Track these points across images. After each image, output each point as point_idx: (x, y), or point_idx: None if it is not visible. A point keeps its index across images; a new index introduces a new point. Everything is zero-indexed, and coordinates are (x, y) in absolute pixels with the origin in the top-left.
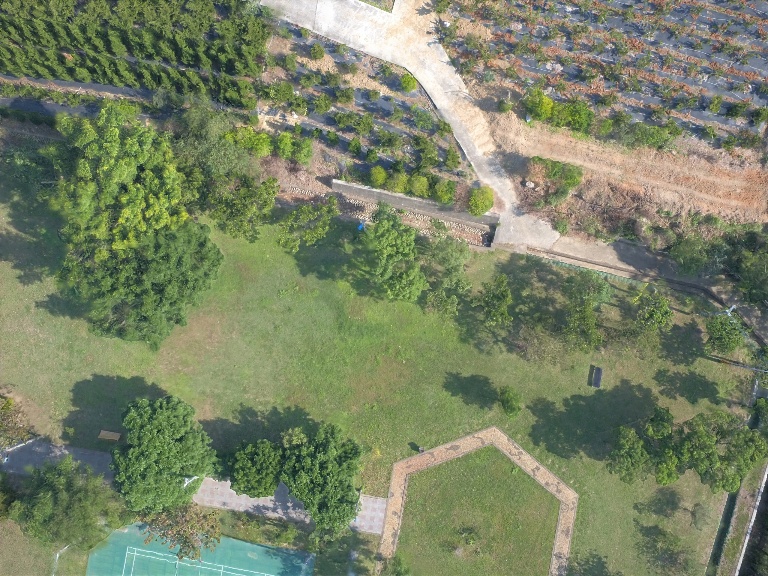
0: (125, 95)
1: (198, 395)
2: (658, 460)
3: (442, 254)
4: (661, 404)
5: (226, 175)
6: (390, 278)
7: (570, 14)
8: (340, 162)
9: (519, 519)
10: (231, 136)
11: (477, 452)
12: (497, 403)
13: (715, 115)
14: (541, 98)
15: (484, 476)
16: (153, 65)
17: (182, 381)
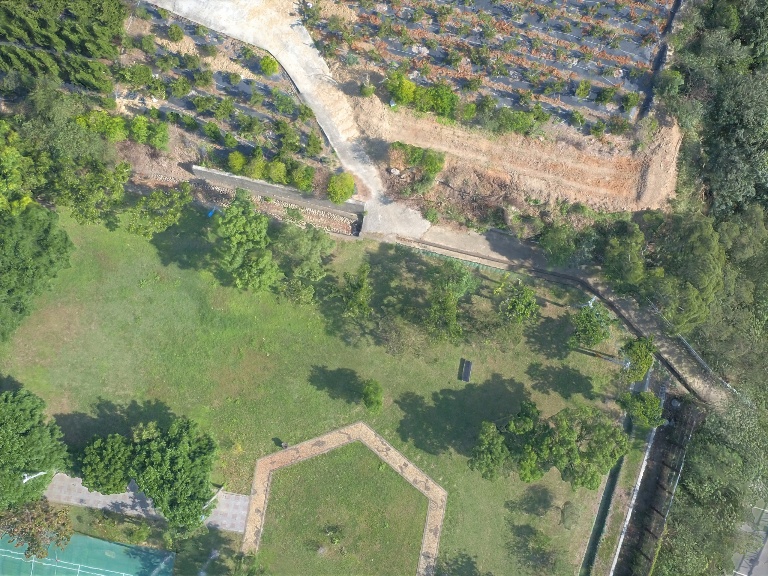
0: None
1: (55, 388)
2: (521, 456)
3: (293, 242)
4: (533, 399)
5: (75, 160)
6: (240, 267)
7: None
8: (200, 147)
9: (386, 517)
10: (83, 120)
11: (343, 448)
12: None
13: (585, 100)
14: (401, 81)
15: (350, 473)
16: None
17: (39, 374)
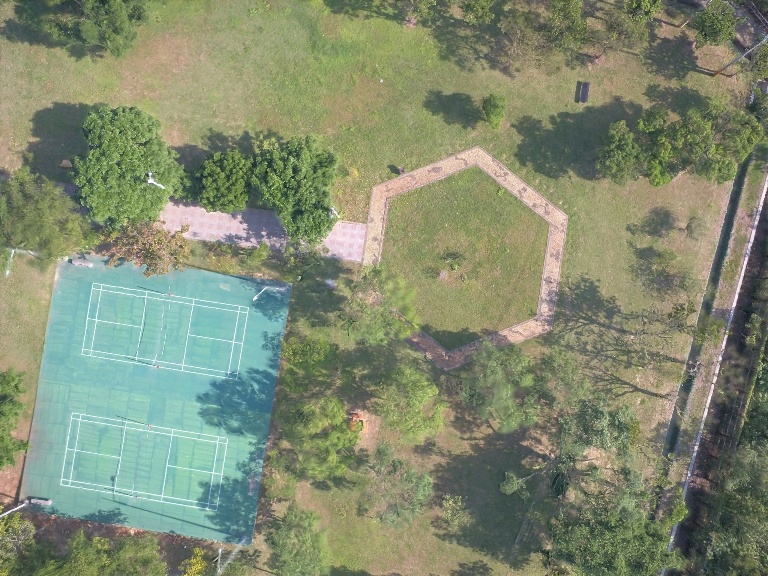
0: None
1: (165, 121)
2: (650, 157)
3: None
4: None
5: None
6: None
7: None
8: None
9: (506, 243)
10: None
11: (460, 174)
12: (480, 122)
13: None
14: None
15: (468, 198)
16: None
17: (148, 106)
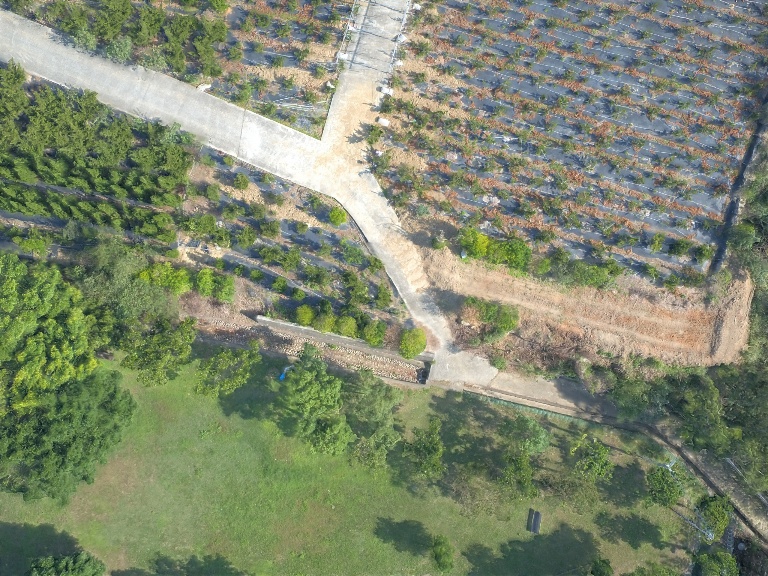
0: (36, 222)
1: (112, 543)
2: None
3: (368, 408)
4: (603, 550)
5: (140, 317)
6: (313, 432)
7: (508, 144)
8: (265, 297)
9: None
10: (147, 273)
11: None
12: (432, 550)
13: (657, 252)
14: (475, 237)
15: None
16: (66, 191)
17: (95, 528)
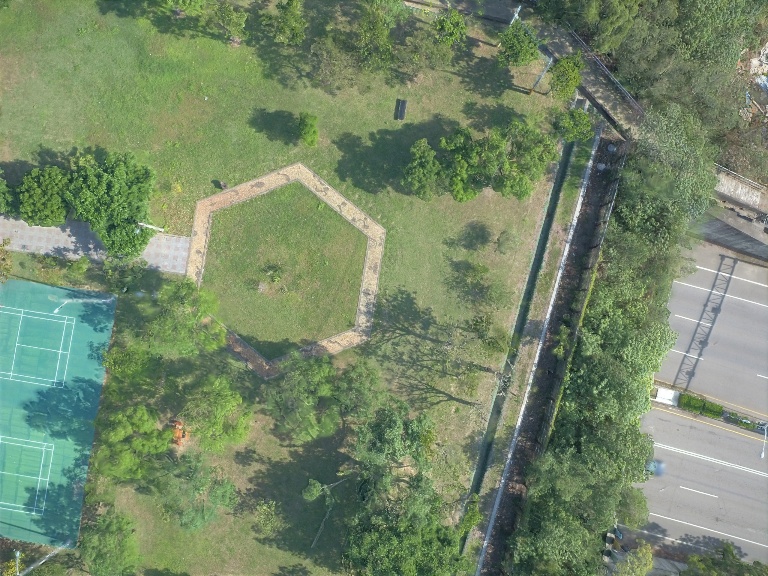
0: None
1: None
2: (453, 174)
3: None
4: None
5: None
6: None
7: None
8: None
9: (326, 256)
10: None
11: (282, 189)
12: None
13: None
14: None
15: (289, 213)
16: None
17: None
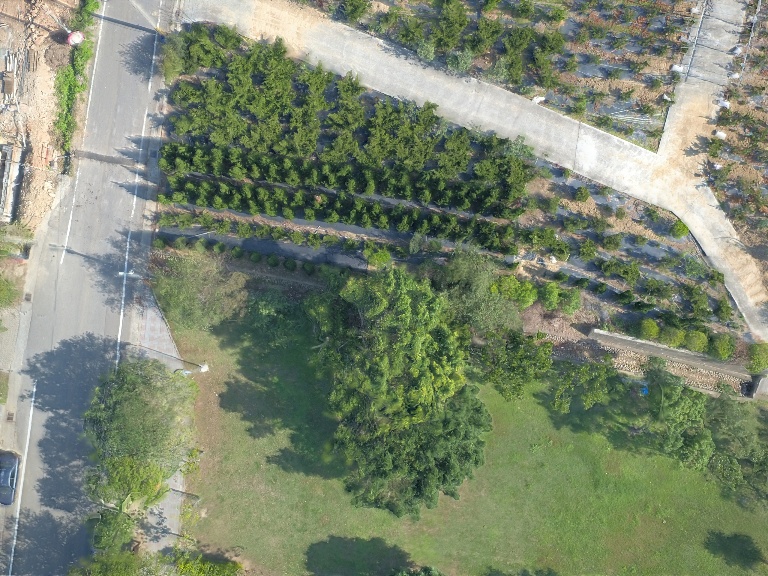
0: (368, 235)
1: (444, 558)
2: None
3: (738, 423)
4: None
5: (496, 332)
6: (680, 447)
7: None
8: (603, 311)
9: None
10: (496, 287)
11: None
12: (762, 565)
13: None
14: None
15: None
16: (401, 204)
17: (427, 543)
